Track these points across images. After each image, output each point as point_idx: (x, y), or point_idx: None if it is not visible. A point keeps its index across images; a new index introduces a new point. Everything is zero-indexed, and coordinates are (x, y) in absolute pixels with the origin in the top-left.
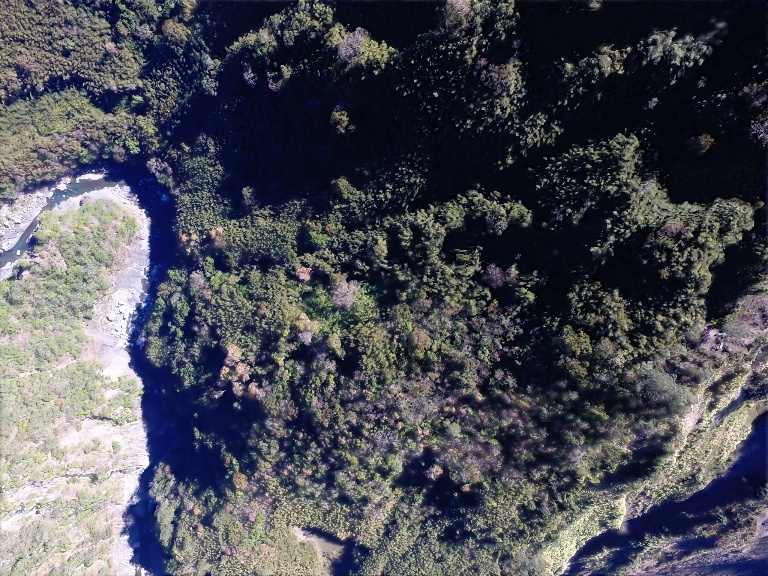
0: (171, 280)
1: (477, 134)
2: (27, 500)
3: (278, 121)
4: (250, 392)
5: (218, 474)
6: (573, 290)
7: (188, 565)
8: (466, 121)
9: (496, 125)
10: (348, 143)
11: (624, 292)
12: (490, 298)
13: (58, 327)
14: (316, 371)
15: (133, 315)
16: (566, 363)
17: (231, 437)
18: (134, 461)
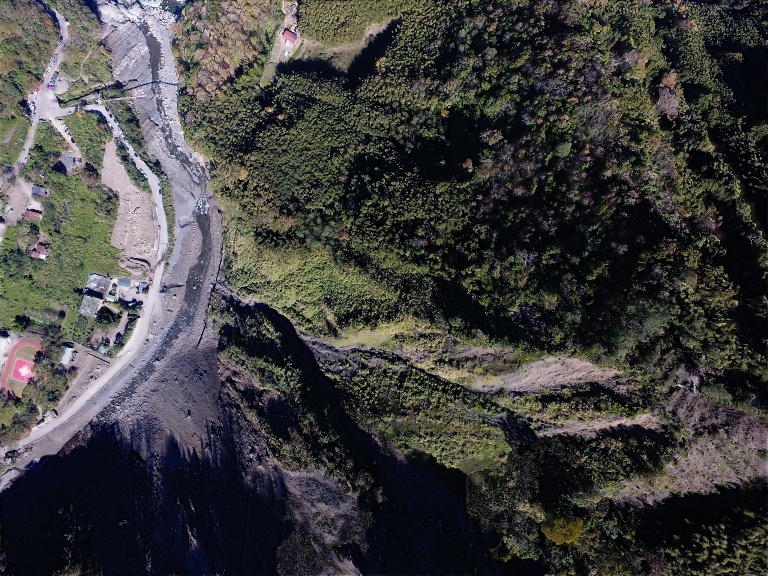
0: None
1: None
2: None
3: None
4: None
5: None
6: None
7: None
8: None
9: None
10: None
11: None
12: None
13: None
14: None
15: None
16: None
17: None
18: None
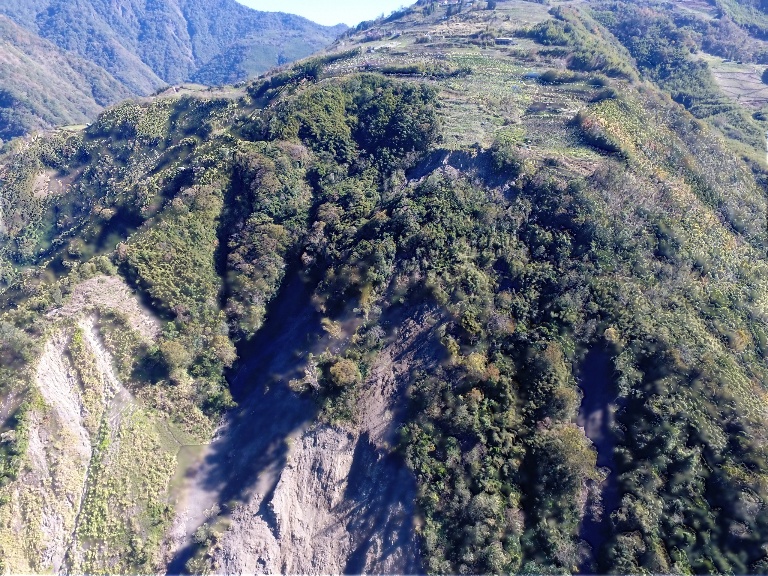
0: None
1: None
2: None
3: None
4: None
5: None
6: None
7: None
8: None
9: None
10: None
11: None
12: None
13: None
14: None
15: None
16: None
17: None
18: None
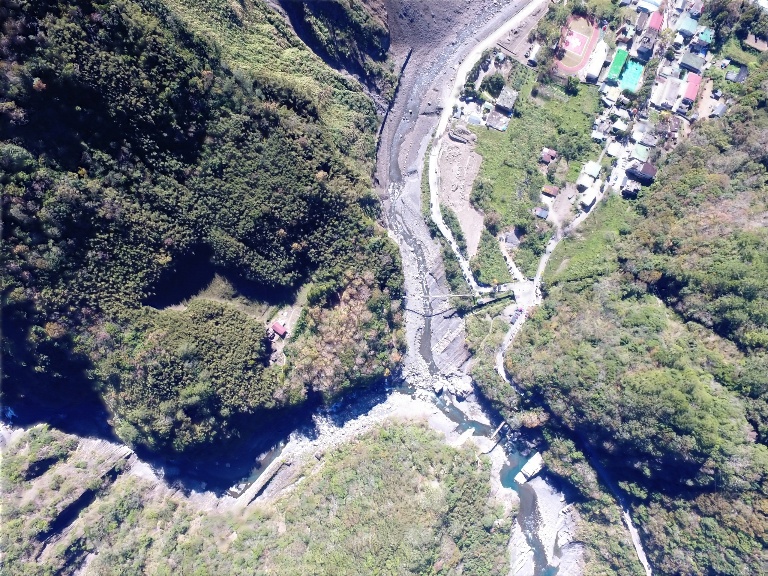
0: None
1: None
2: None
3: None
4: None
5: (68, 357)
6: None
7: None
8: None
9: None
10: None
11: None
12: None
13: None
14: None
15: None
16: None
17: None
18: (115, 458)
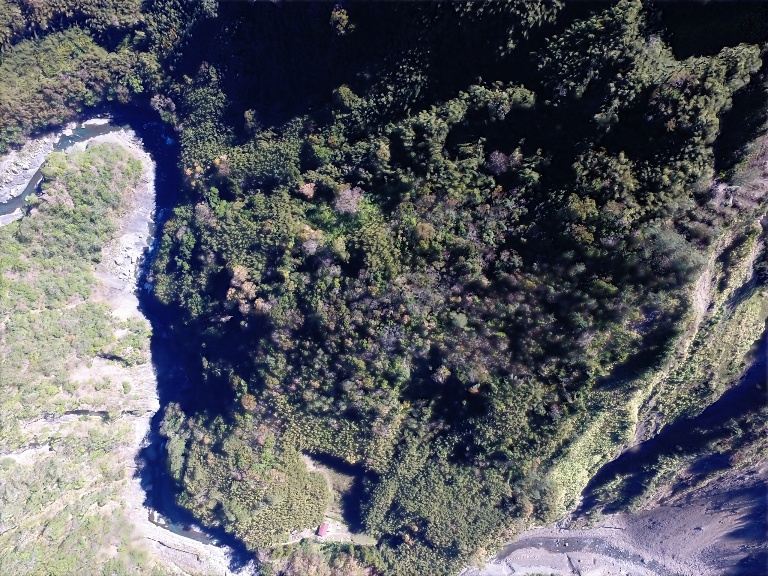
0: (177, 217)
1: (477, 17)
2: (40, 433)
3: (279, 38)
4: (256, 307)
5: (227, 400)
6: (578, 159)
7: (199, 494)
8: (466, 4)
9: (496, 4)
10: (348, 47)
11: (630, 154)
12: (494, 185)
13: (67, 267)
14: (321, 277)
15: (141, 259)
16: (572, 231)
17: (239, 360)
18: (145, 403)
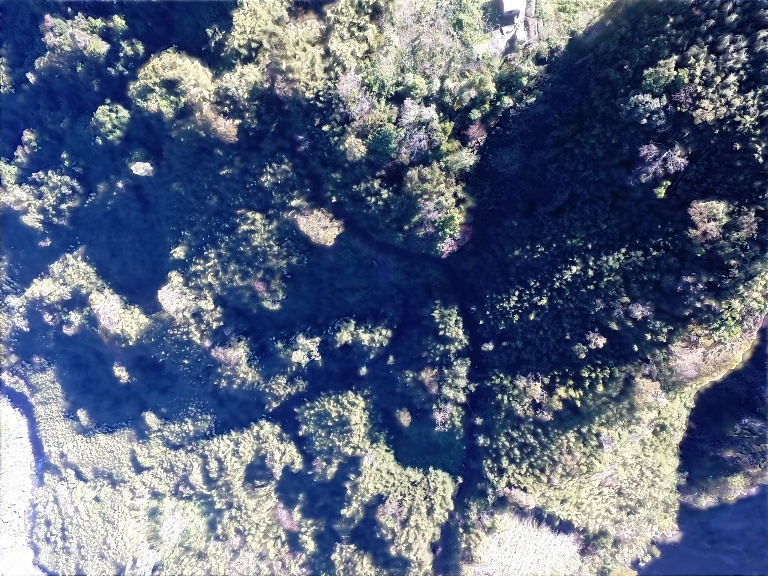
0: (47, 485)
1: None
2: None
3: (90, 350)
4: None
5: None
6: (334, 551)
7: None
8: (221, 380)
9: (246, 384)
10: None
11: (373, 557)
12: (284, 538)
13: None
14: None
15: (28, 511)
16: None
17: None
18: None
